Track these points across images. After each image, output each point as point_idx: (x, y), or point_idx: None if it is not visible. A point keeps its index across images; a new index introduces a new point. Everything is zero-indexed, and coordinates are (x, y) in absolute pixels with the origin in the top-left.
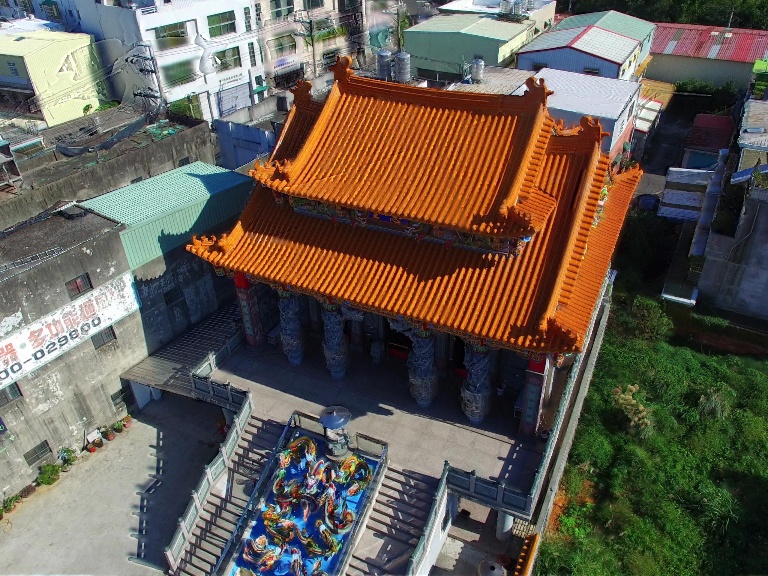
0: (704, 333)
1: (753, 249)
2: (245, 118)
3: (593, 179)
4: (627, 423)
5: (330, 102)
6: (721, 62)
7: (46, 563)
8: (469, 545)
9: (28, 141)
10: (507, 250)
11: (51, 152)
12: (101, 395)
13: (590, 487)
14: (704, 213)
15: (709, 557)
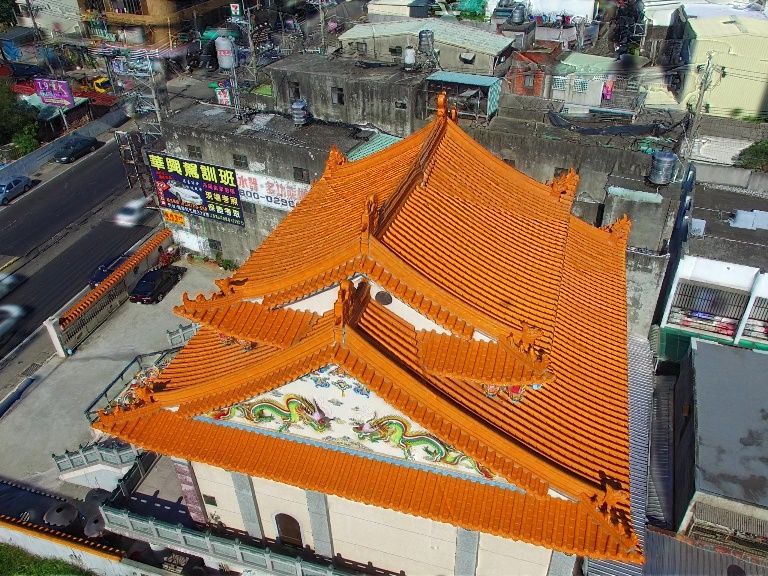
0: None
1: None
2: (740, 181)
3: None
4: None
5: (419, 134)
6: None
7: (192, 298)
8: None
9: (621, 110)
10: None
11: (544, 113)
12: None
13: None
14: None
15: None
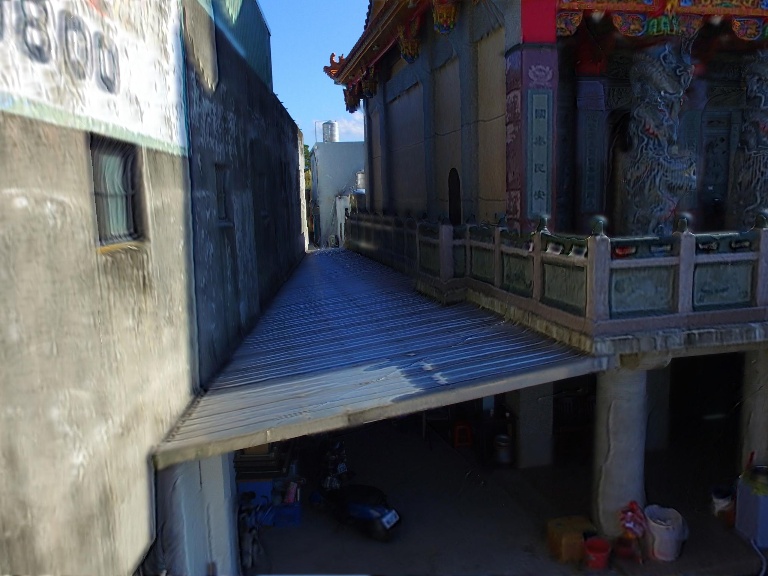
0: None
1: None
2: None
3: None
4: None
5: None
6: None
7: None
8: None
9: None
10: None
11: None
12: (100, 573)
13: None
14: None
15: None
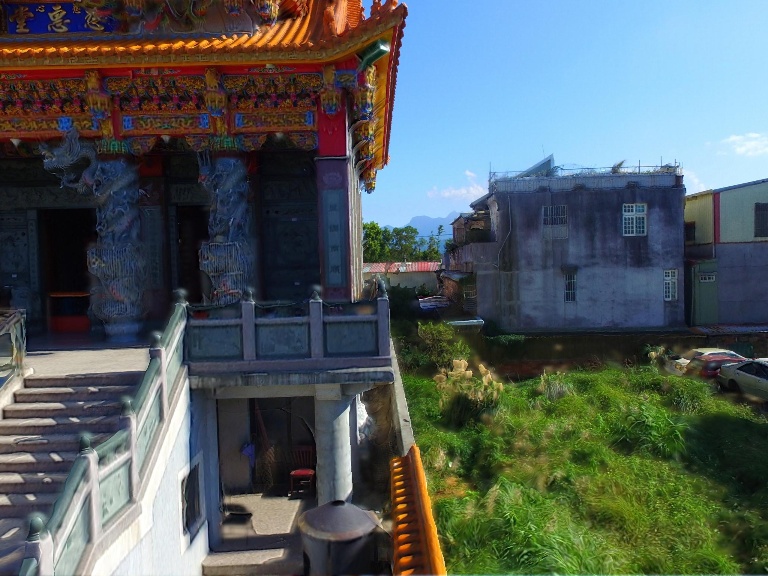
0: (504, 358)
1: (518, 249)
2: None
3: (347, 0)
4: (471, 406)
5: None
6: (411, 274)
7: None
8: (260, 575)
9: None
10: (250, 29)
11: None
12: None
13: (458, 482)
14: (453, 275)
15: (692, 476)
